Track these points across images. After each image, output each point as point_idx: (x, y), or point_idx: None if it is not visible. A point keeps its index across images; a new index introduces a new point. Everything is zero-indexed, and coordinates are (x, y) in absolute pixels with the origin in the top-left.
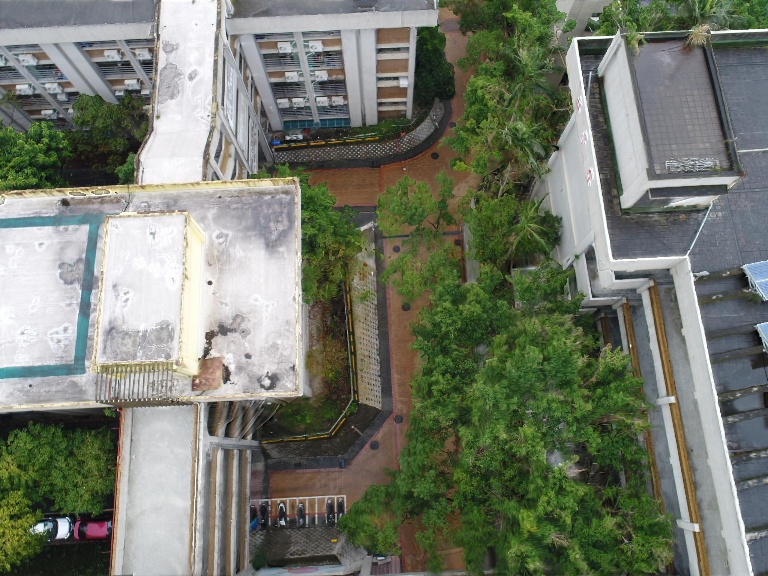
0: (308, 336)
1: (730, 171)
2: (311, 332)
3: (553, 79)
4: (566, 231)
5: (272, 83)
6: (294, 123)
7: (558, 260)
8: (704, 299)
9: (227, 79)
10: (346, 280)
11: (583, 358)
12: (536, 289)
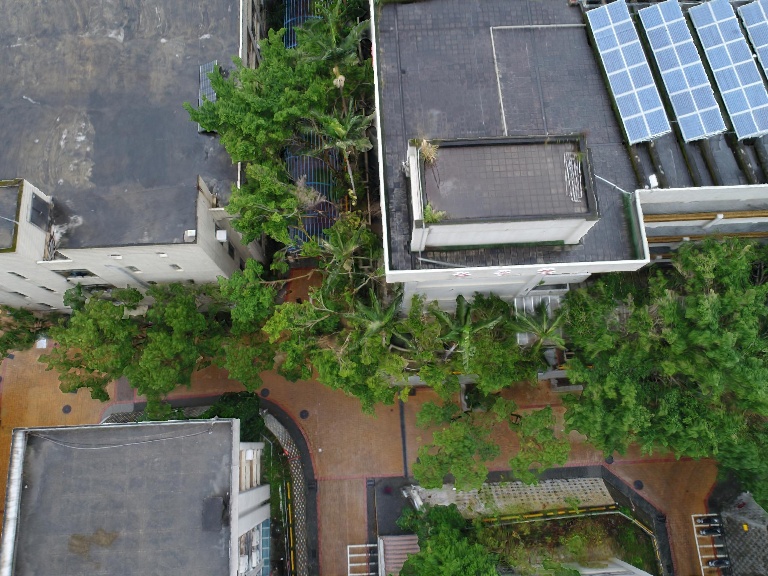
0: None
1: (580, 144)
2: None
3: None
4: (494, 289)
5: None
6: None
7: (508, 298)
8: (665, 181)
9: None
10: (485, 522)
11: (712, 293)
12: (592, 327)
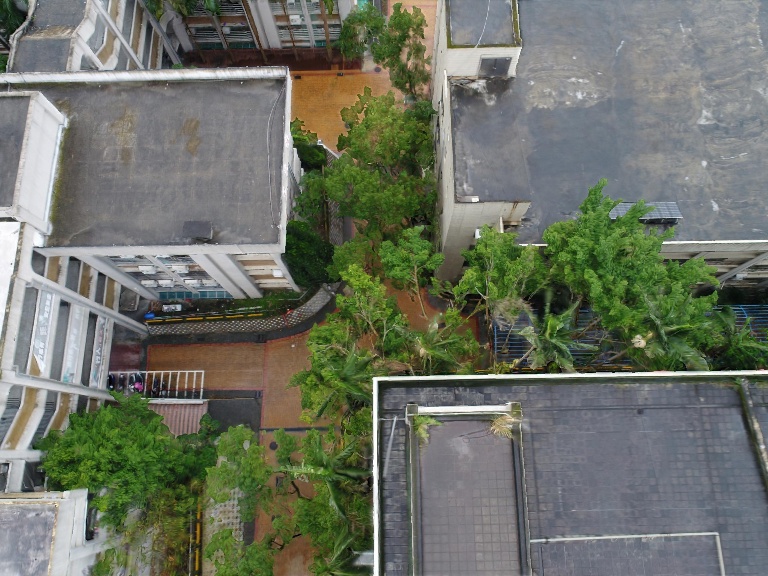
0: (148, 573)
1: None
2: (153, 567)
3: (453, 264)
4: None
5: (128, 272)
6: (171, 293)
7: None
8: None
9: (38, 313)
10: (197, 506)
11: None
12: None
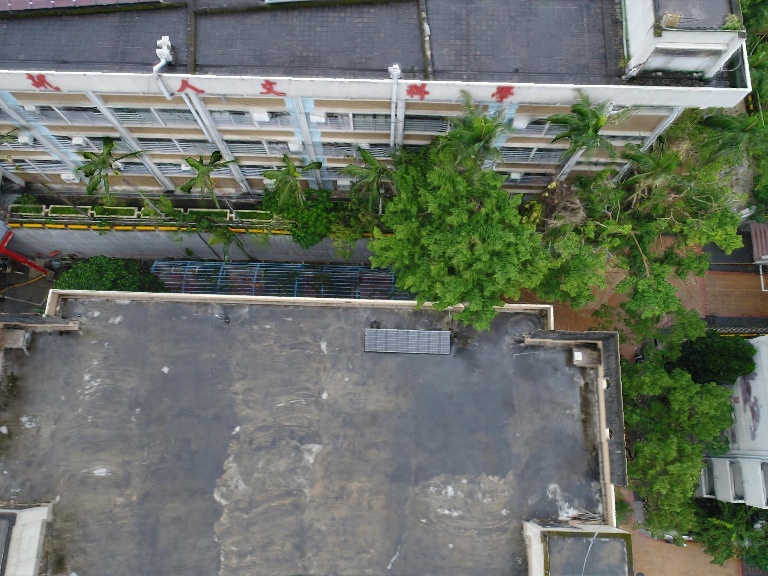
0: None
1: None
2: None
3: None
4: None
5: None
6: None
7: None
8: None
9: None
10: None
11: None
12: None
